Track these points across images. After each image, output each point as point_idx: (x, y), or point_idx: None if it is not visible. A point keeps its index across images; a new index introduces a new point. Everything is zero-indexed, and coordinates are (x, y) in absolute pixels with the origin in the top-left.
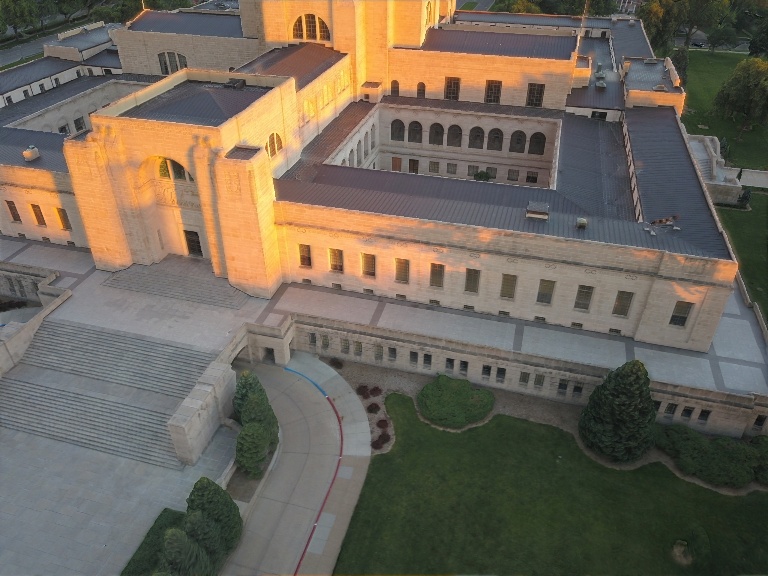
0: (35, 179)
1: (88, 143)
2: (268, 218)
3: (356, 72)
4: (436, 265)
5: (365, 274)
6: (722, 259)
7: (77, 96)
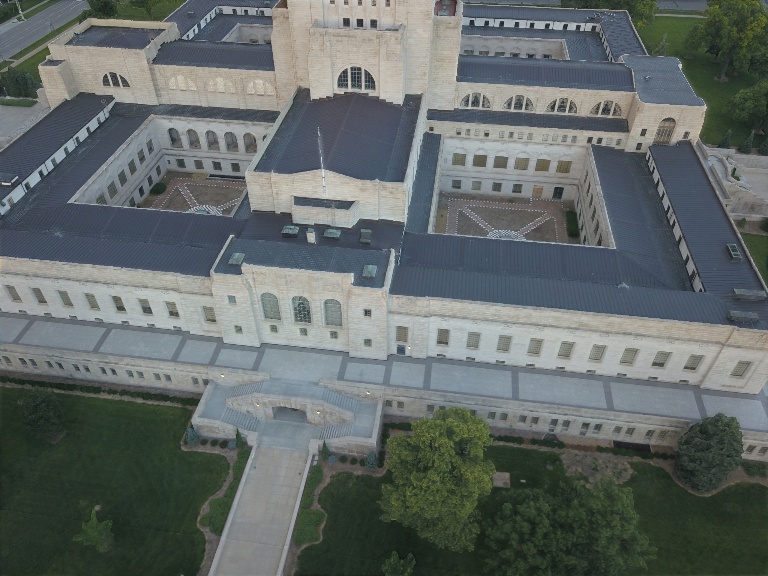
0: None
1: None
2: None
3: (278, 89)
4: None
5: None
6: None
7: None
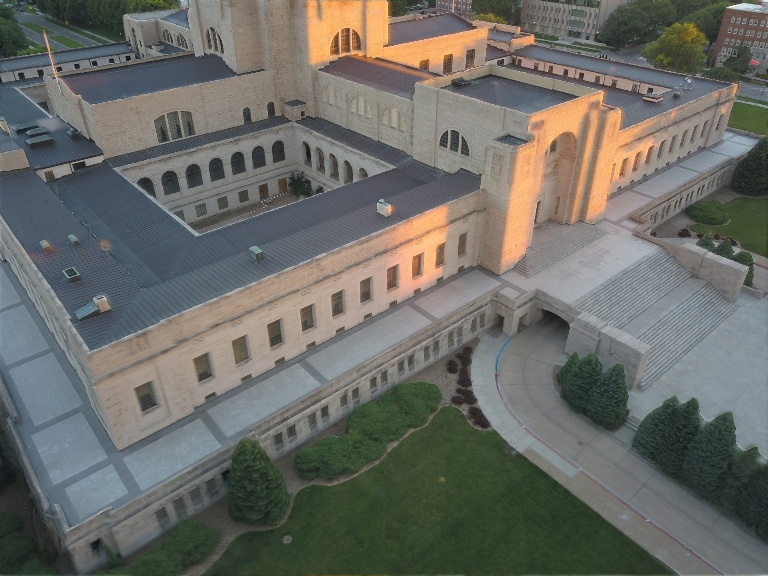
0: (430, 222)
1: (534, 141)
2: None
3: None
4: (649, 148)
5: (619, 176)
6: None
7: (143, 191)
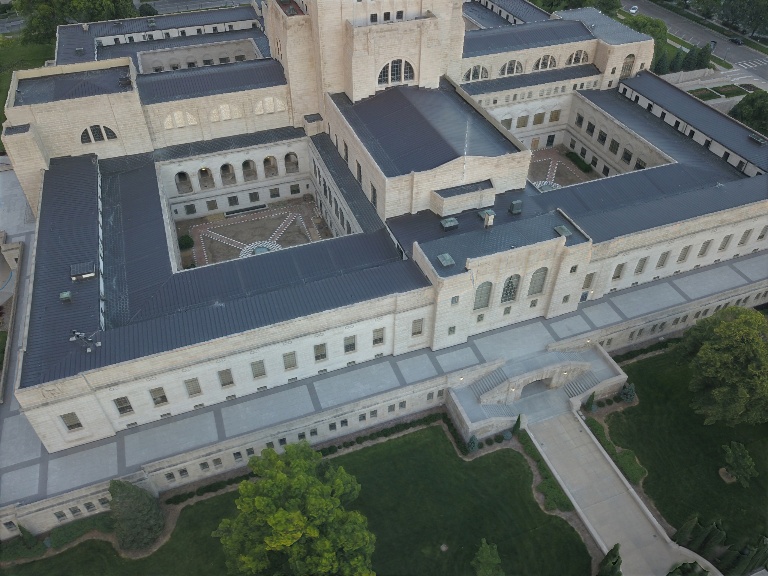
0: None
1: None
2: (34, 178)
3: (292, 102)
4: None
5: None
6: (19, 382)
7: (209, 44)
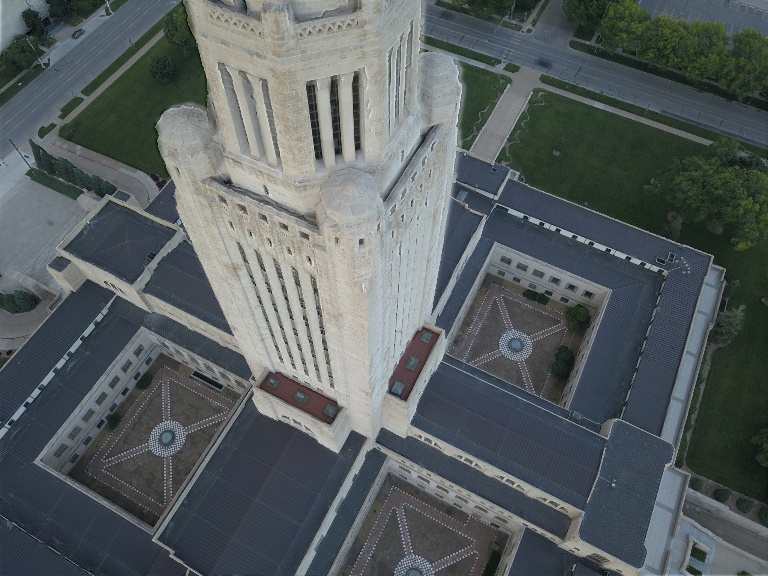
0: None
1: None
2: None
3: None
4: None
5: None
6: None
7: None
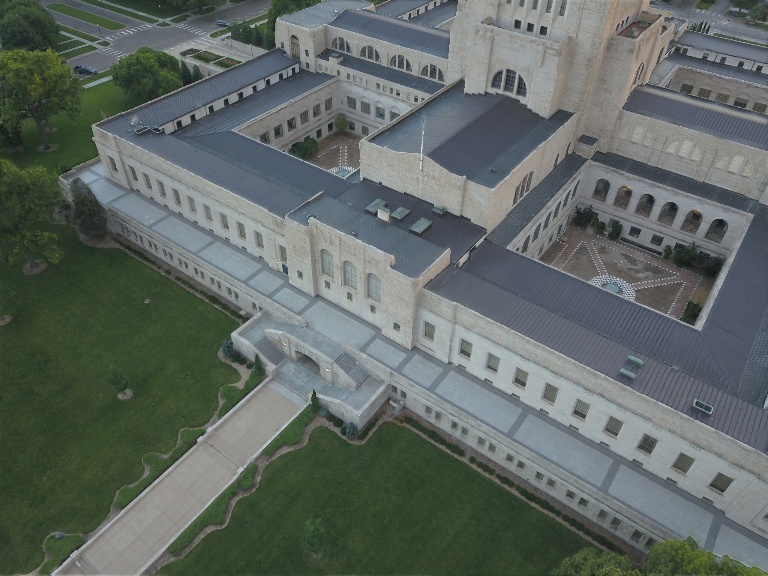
0: None
1: None
2: None
3: None
4: None
5: None
6: None
7: None
